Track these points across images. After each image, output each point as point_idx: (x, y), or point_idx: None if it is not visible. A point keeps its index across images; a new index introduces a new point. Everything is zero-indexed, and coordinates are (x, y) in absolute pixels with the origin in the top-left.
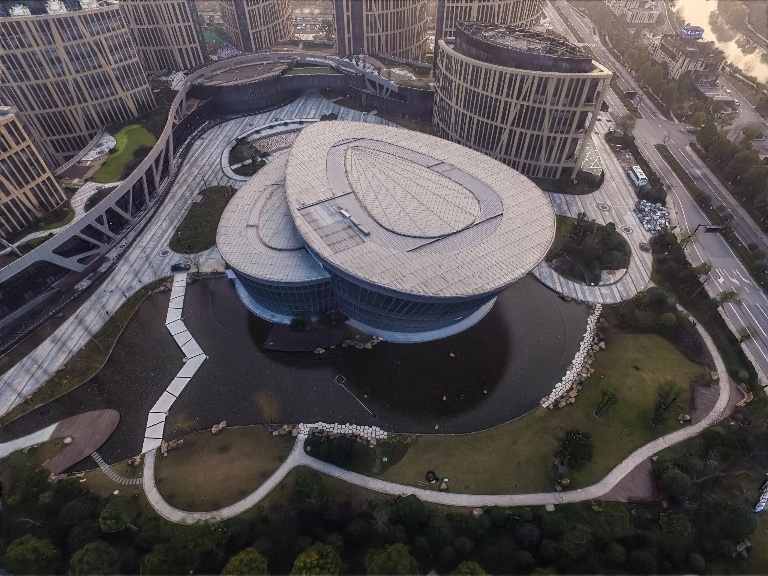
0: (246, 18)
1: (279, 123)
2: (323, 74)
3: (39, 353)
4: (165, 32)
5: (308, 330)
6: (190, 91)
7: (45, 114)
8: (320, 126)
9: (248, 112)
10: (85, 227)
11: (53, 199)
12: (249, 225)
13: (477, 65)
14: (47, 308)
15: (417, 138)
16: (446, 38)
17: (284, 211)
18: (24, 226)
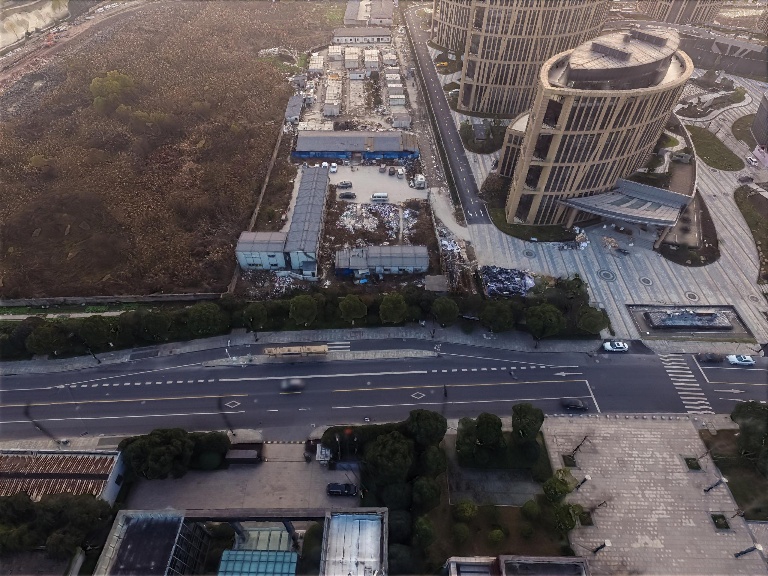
0: None
1: None
2: None
3: (725, 235)
4: None
5: None
6: None
7: None
8: None
9: None
10: None
11: None
12: None
13: None
14: None
15: None
16: None
17: None
18: None
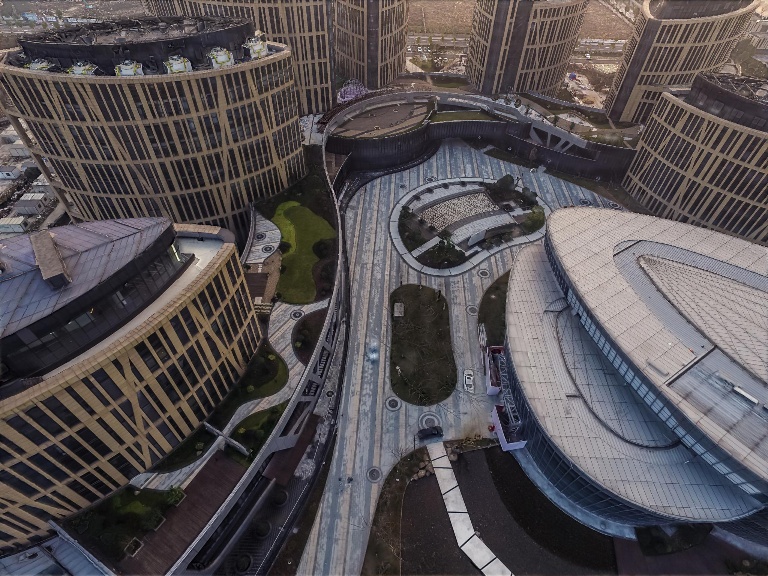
0: (377, 49)
1: (437, 184)
2: (478, 121)
3: None
4: (295, 70)
5: (670, 552)
6: (326, 144)
7: (186, 195)
8: (568, 217)
9: (391, 168)
10: (305, 386)
11: (252, 343)
12: (569, 395)
13: (758, 136)
14: (272, 519)
15: (716, 241)
16: (669, 89)
17: (598, 365)
18: (226, 393)
